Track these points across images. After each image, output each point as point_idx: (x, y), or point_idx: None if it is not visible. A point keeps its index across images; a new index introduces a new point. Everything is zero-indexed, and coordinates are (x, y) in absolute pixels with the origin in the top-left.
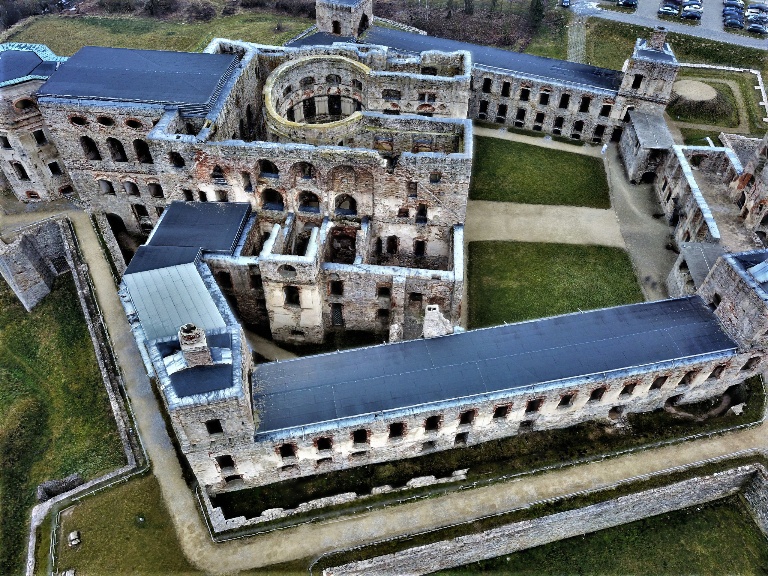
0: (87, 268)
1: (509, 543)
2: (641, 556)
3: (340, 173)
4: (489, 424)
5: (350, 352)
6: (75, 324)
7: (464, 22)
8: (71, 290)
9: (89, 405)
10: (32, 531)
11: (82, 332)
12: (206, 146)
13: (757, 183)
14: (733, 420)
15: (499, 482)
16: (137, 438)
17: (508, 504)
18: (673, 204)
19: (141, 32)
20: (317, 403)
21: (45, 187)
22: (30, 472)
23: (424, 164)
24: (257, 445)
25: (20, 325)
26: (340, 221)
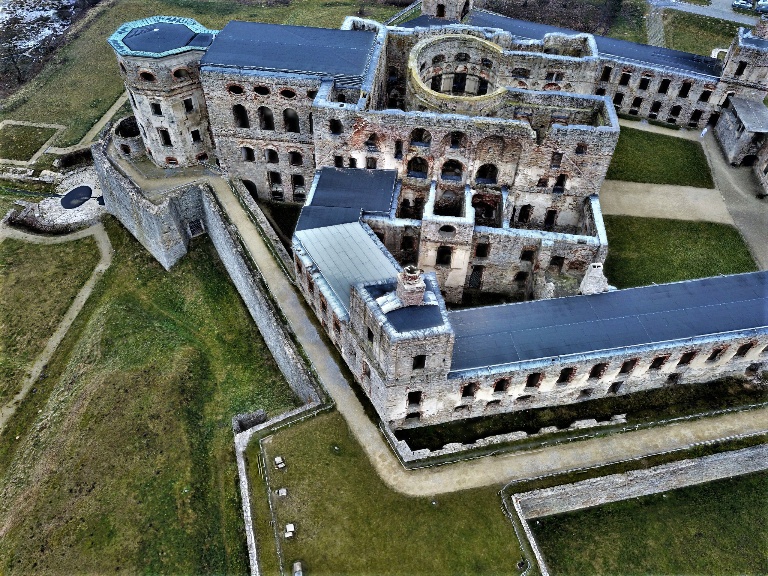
0: (236, 229)
1: (668, 480)
2: None
3: (489, 143)
4: (643, 374)
5: (519, 304)
6: (216, 282)
7: (541, 11)
8: (206, 252)
9: (246, 354)
10: (239, 456)
11: (225, 289)
12: (368, 114)
13: None
14: None
15: (658, 425)
16: (316, 379)
17: (669, 445)
18: None
19: (224, 13)
20: (499, 347)
21: (185, 153)
22: (203, 411)
23: (574, 136)
24: (448, 382)
25: (161, 283)
26: (483, 189)
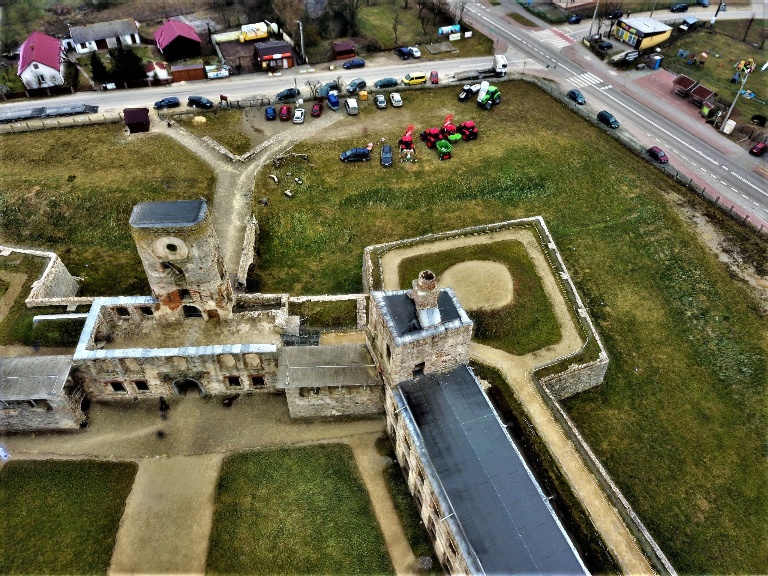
0: None
1: None
2: (633, 497)
3: None
4: None
5: None
6: None
7: None
8: None
9: None
10: None
11: None
12: None
13: (196, 289)
14: (501, 390)
15: None
16: None
17: None
18: (164, 383)
19: None
20: None
21: None
22: None
23: None
24: None
25: None
26: None
